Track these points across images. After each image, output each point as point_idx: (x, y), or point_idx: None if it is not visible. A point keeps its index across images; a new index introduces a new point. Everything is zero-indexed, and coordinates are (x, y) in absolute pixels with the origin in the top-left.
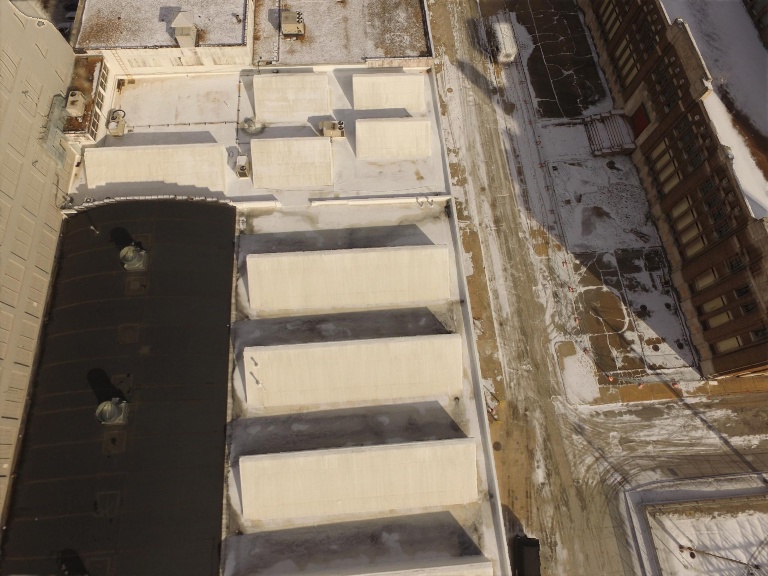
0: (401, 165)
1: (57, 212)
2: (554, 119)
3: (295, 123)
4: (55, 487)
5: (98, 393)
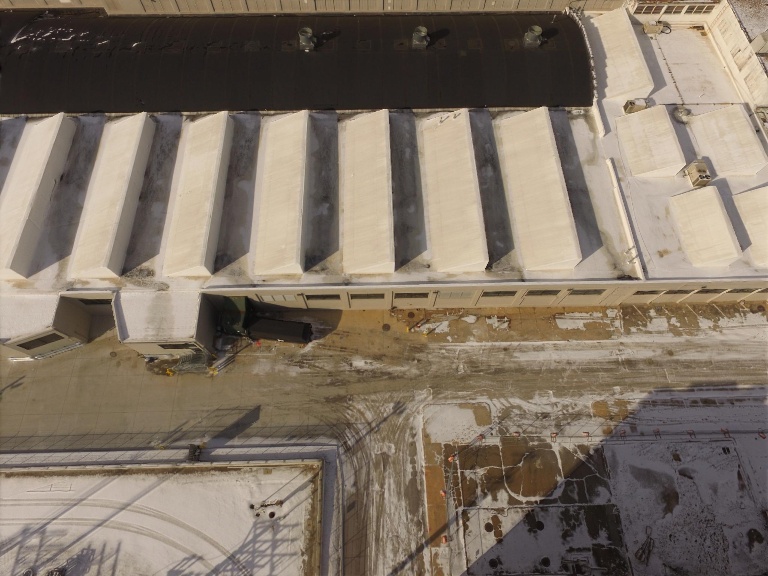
0: (673, 237)
1: (566, 5)
2: None
3: (697, 147)
4: (376, 25)
5: (433, 34)
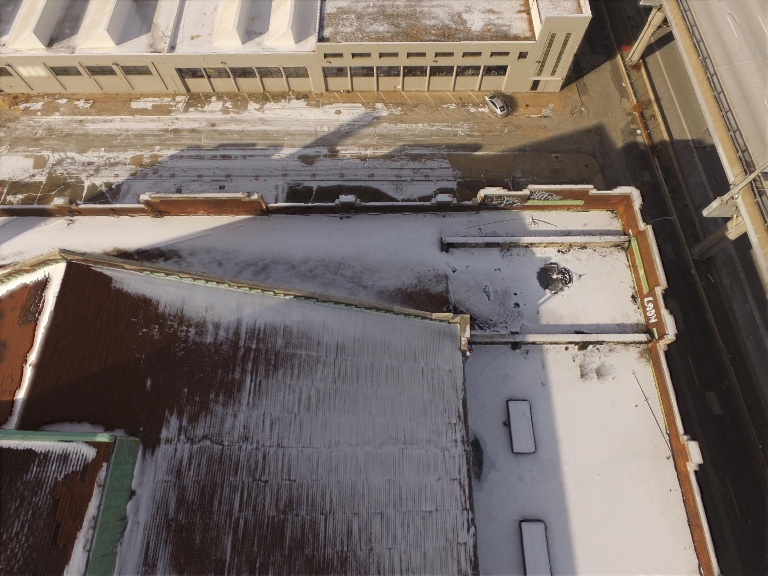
0: (209, 26)
1: None
2: (283, 196)
3: None
4: None
5: None
